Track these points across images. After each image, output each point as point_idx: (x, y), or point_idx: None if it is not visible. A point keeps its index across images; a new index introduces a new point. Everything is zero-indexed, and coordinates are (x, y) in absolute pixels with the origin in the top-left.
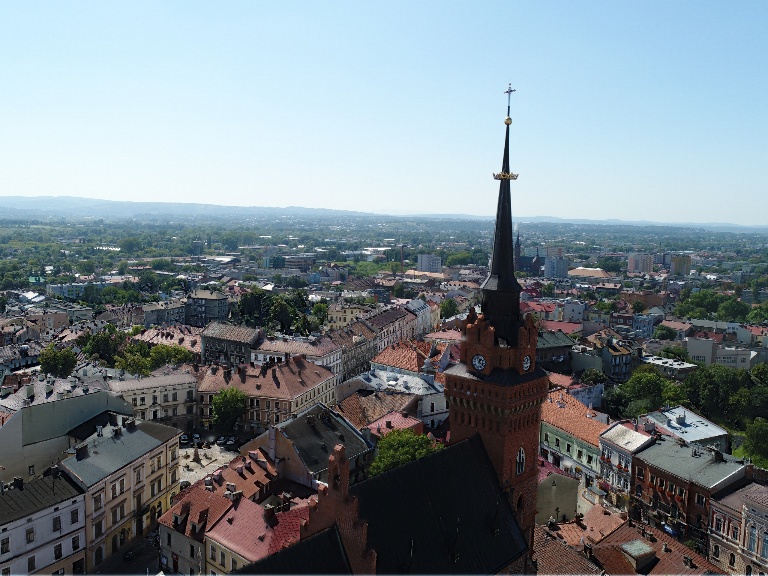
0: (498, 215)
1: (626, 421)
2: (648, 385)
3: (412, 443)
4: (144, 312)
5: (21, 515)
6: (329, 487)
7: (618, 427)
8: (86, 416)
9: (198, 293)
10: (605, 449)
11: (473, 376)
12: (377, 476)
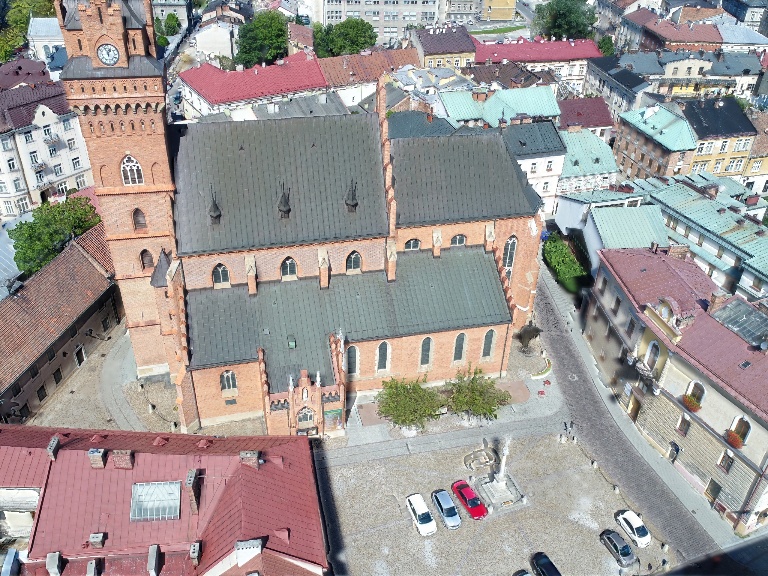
0: None
1: None
2: None
3: None
4: None
5: None
6: None
7: None
8: None
9: None
10: None
11: None
12: (335, 116)
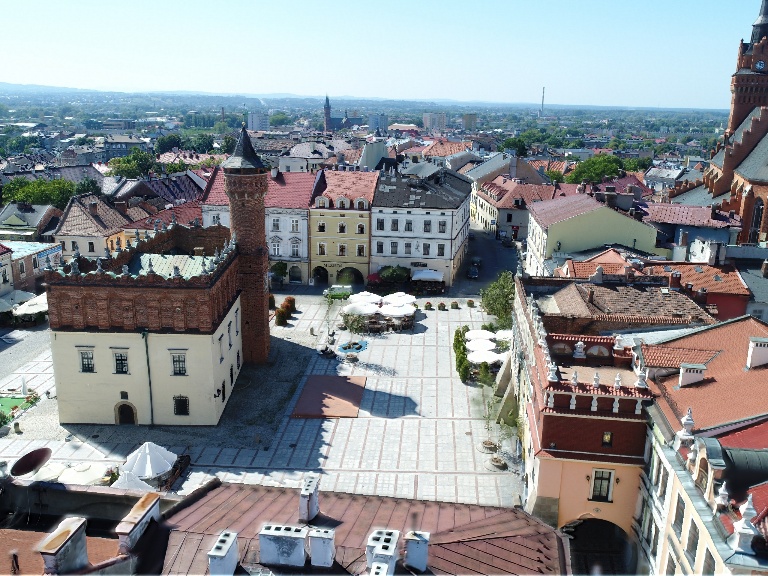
0: None
1: (654, 167)
2: (616, 162)
3: (603, 161)
4: (77, 155)
5: (470, 189)
6: None
7: (654, 169)
8: (378, 159)
9: (115, 138)
10: (650, 183)
11: (757, 73)
12: None
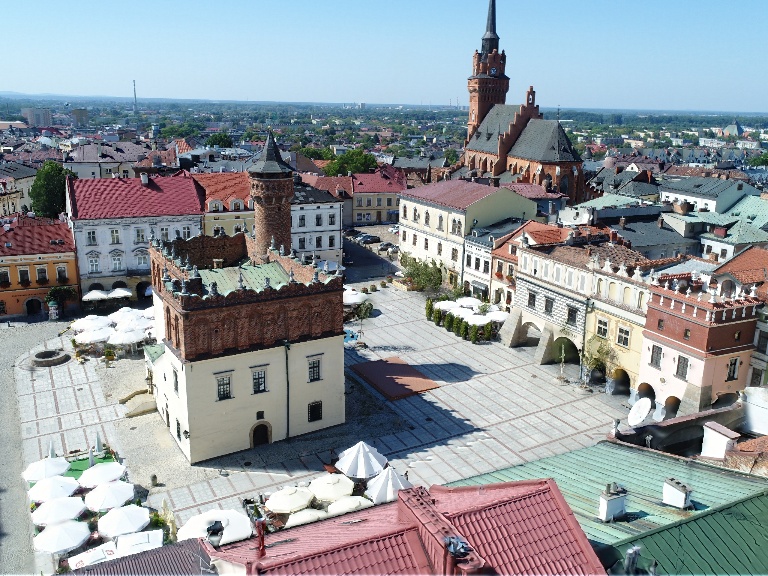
0: (492, 4)
1: None
2: (315, 153)
3: (361, 153)
4: None
5: None
6: (527, 104)
7: None
8: None
9: None
10: None
11: (493, 77)
12: None
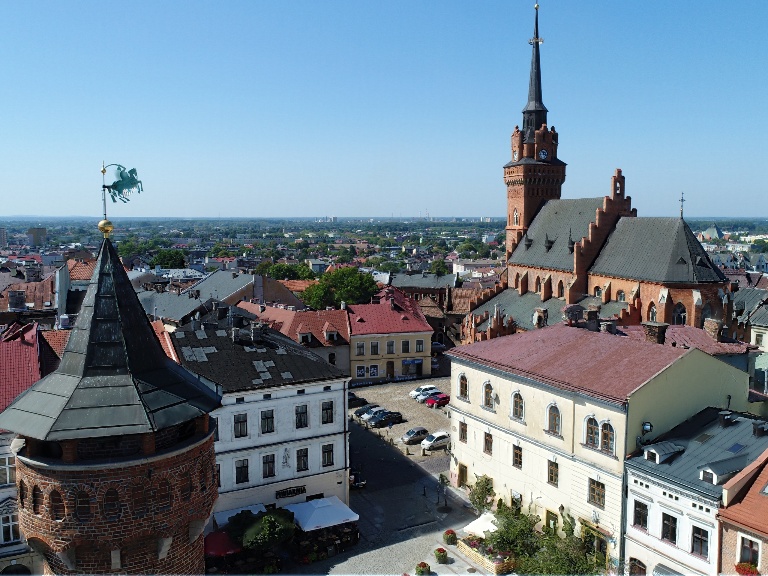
0: (536, 64)
1: None
2: (289, 271)
3: (354, 272)
4: None
5: None
6: (614, 195)
7: None
8: None
9: None
10: None
11: (543, 162)
12: None
